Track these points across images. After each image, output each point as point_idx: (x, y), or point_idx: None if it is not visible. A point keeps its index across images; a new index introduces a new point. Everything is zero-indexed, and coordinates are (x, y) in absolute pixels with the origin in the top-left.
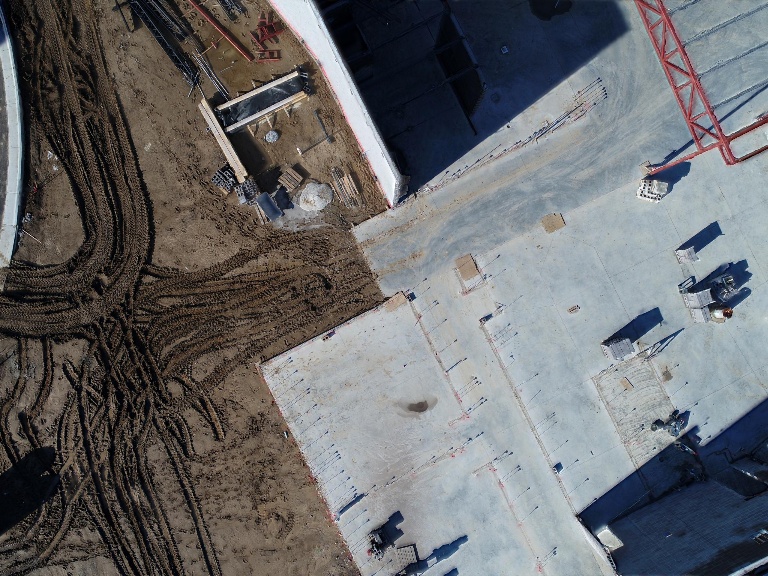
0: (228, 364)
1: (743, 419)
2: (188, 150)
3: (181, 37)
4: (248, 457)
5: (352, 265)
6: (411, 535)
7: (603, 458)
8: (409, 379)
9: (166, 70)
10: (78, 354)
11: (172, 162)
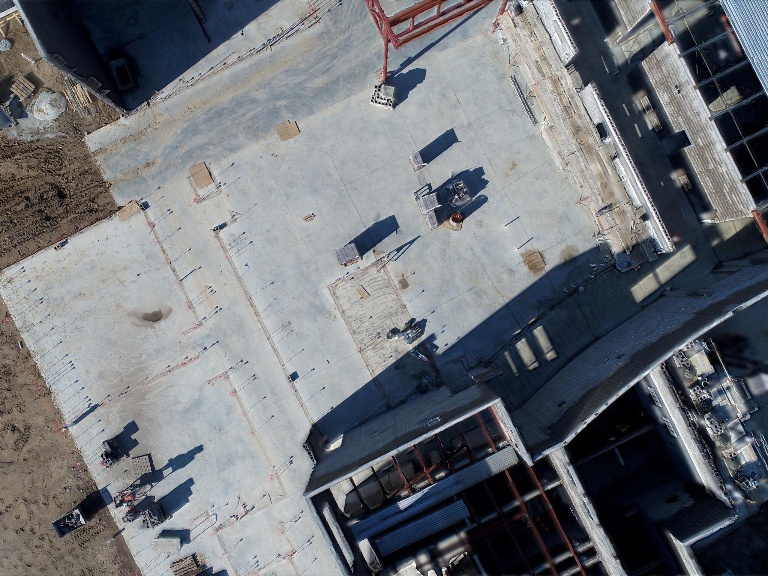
0: None
1: (480, 327)
2: None
3: None
4: None
5: (85, 174)
6: (146, 445)
7: (339, 366)
8: (143, 288)
9: None
10: None
11: None
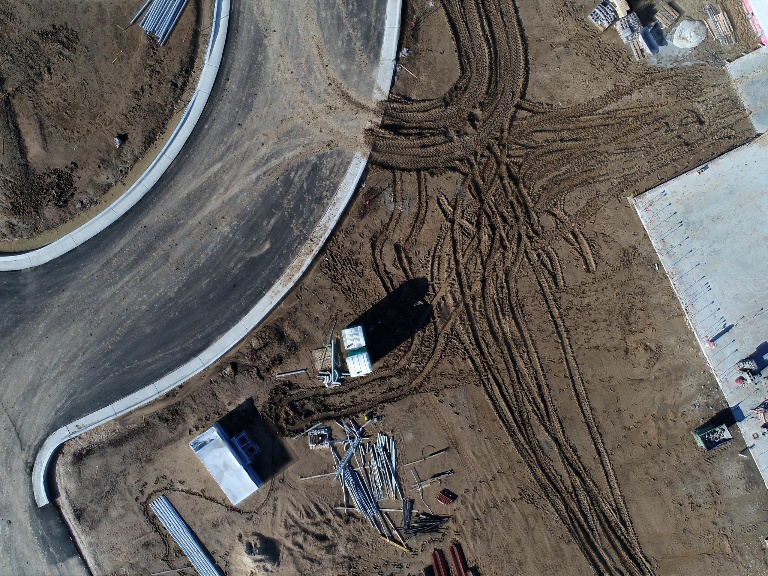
0: (600, 198)
1: None
2: None
3: None
4: (618, 288)
5: (726, 101)
6: None
7: None
8: None
9: None
10: (452, 187)
11: None
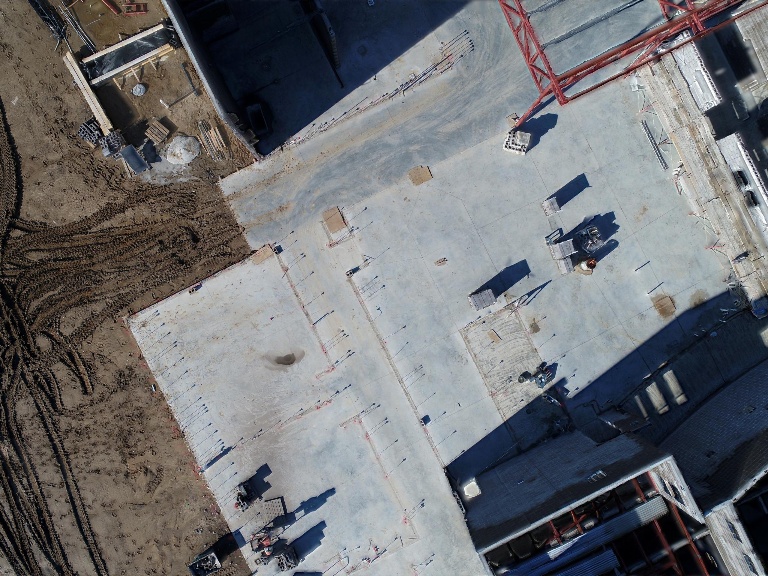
0: (96, 318)
1: (610, 371)
2: (55, 104)
3: None
4: (116, 411)
5: (219, 218)
6: (279, 488)
7: (471, 410)
8: (276, 332)
9: (33, 23)
10: None
11: (39, 116)
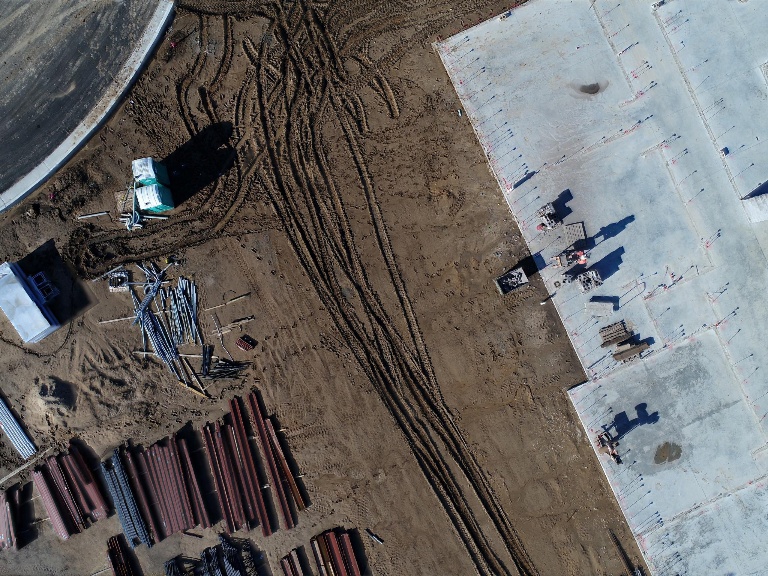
0: (405, 44)
1: None
2: None
3: None
4: (422, 134)
5: None
6: (579, 213)
7: None
8: (582, 61)
9: None
10: (258, 32)
11: None
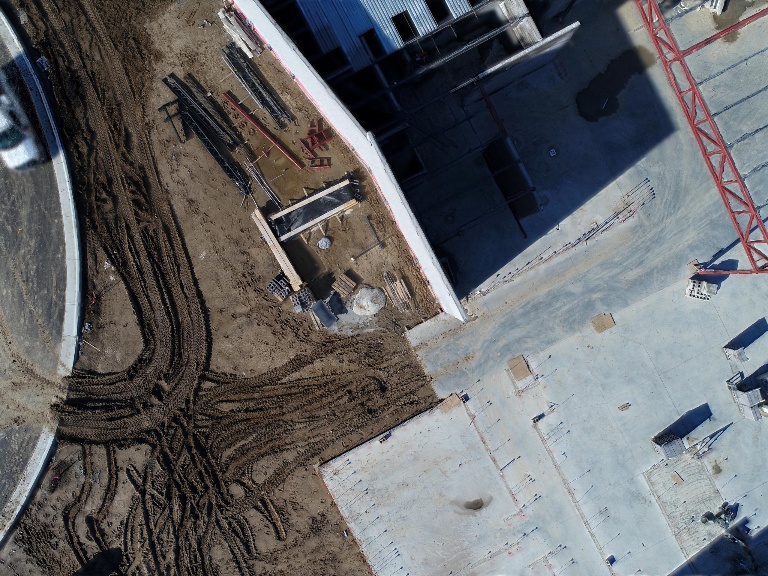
0: (287, 466)
1: None
2: (242, 258)
3: (232, 147)
4: (309, 555)
5: (406, 368)
6: None
7: (654, 550)
8: (464, 478)
9: (218, 180)
10: (141, 459)
11: (227, 270)
